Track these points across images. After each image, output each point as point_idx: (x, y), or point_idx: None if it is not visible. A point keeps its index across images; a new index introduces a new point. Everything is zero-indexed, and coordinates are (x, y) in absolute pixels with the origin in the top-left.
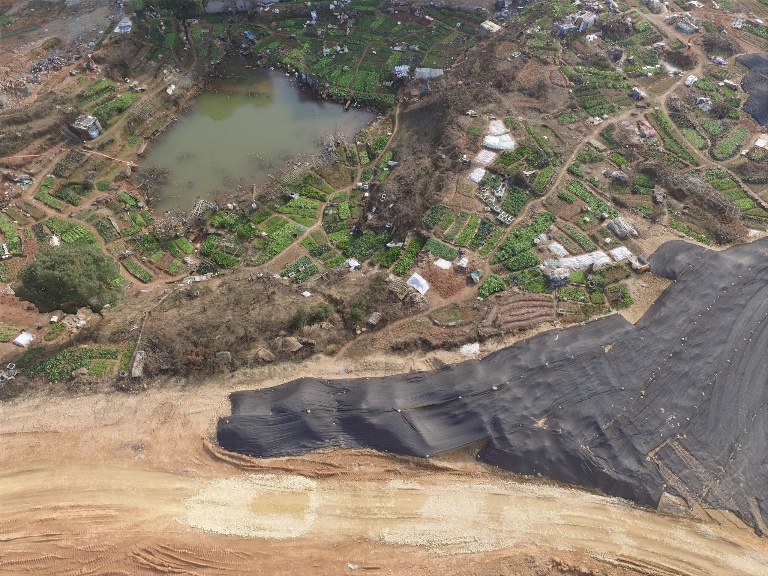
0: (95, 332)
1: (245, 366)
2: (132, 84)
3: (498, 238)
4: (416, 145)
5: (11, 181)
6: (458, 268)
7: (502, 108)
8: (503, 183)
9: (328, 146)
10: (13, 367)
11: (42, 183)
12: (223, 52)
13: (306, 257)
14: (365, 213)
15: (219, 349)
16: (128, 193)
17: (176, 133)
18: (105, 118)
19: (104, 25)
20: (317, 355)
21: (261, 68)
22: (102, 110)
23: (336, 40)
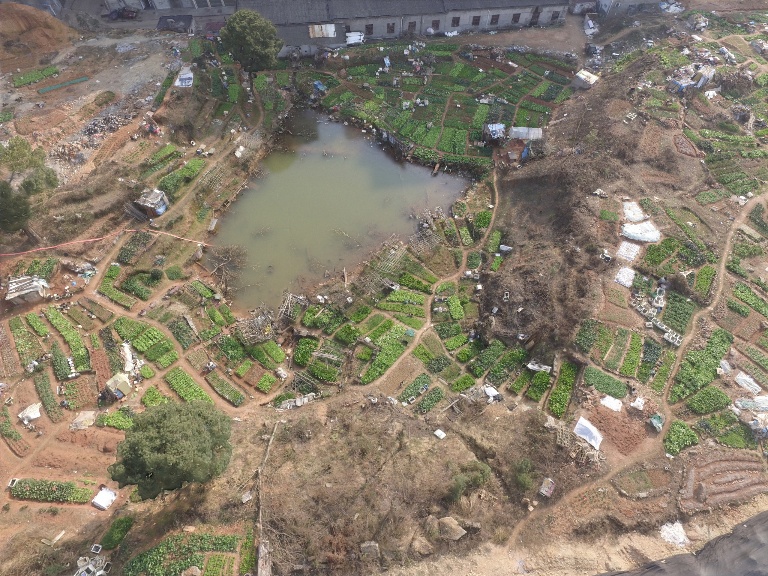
0: (203, 508)
1: (398, 563)
2: (199, 148)
3: (670, 366)
4: (531, 226)
5: (71, 272)
6: (632, 410)
7: (633, 186)
8: (659, 288)
9: (423, 221)
10: (99, 550)
11: (106, 273)
12: (290, 104)
13: (425, 374)
14: (483, 313)
15: (363, 538)
16: (204, 284)
17: (248, 203)
18: (172, 191)
19: (161, 75)
20: (485, 545)
21: (334, 123)
22: (169, 181)
23: (414, 90)
